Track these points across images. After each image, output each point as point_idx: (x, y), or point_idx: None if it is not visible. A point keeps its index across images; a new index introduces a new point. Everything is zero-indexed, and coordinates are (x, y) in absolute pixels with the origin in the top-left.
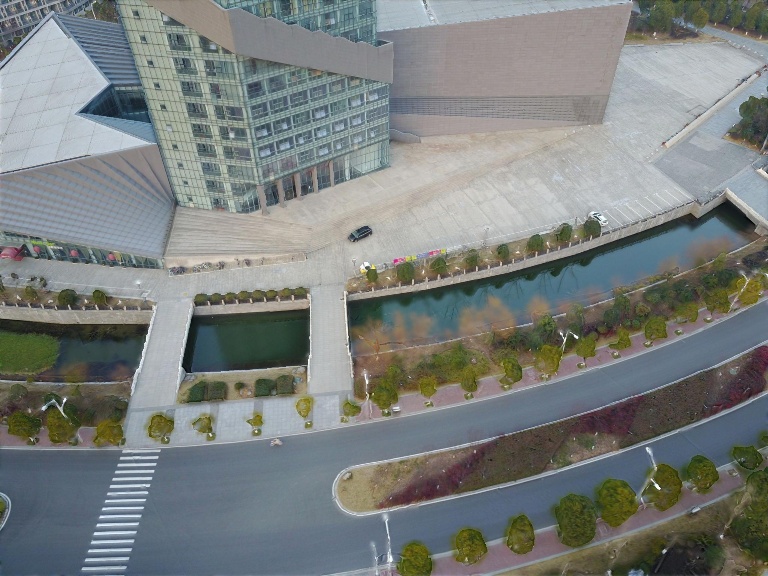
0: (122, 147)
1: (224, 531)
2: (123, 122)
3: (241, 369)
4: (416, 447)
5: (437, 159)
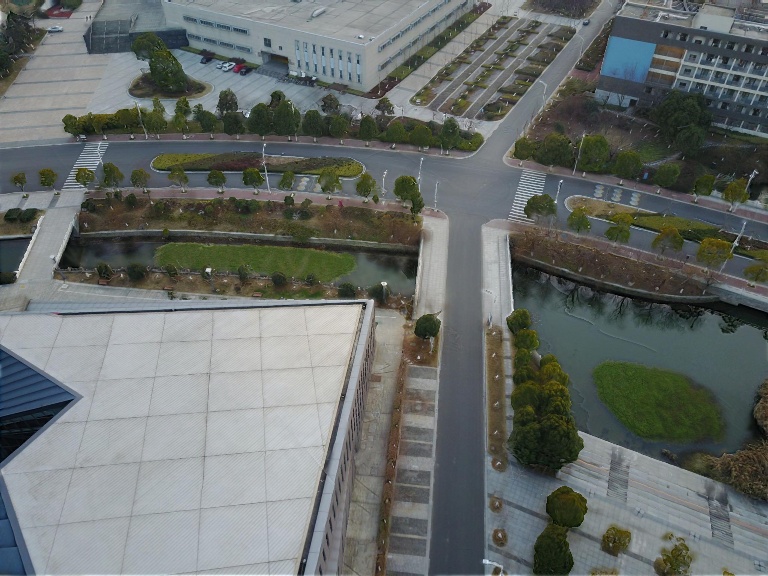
0: (7, 318)
1: (28, 162)
2: (4, 399)
3: None
4: None
5: None
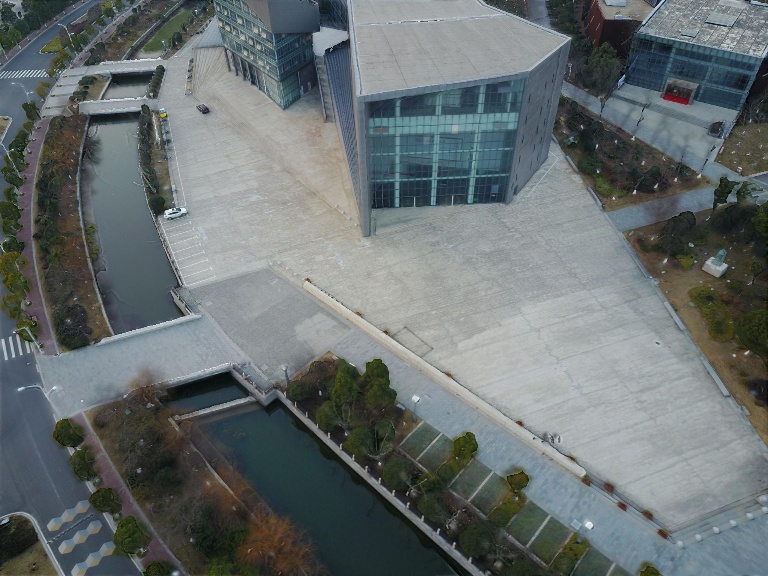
0: None
1: (3, 94)
2: None
3: (108, 92)
4: (8, 136)
5: (294, 131)
